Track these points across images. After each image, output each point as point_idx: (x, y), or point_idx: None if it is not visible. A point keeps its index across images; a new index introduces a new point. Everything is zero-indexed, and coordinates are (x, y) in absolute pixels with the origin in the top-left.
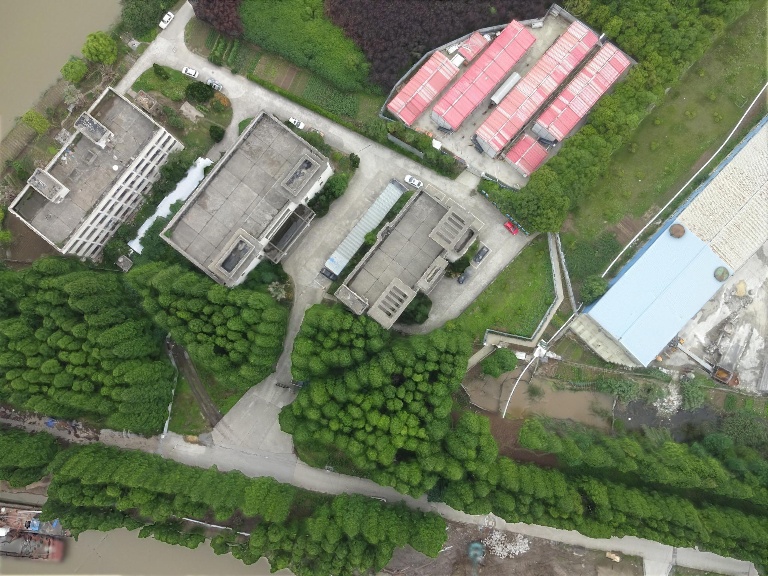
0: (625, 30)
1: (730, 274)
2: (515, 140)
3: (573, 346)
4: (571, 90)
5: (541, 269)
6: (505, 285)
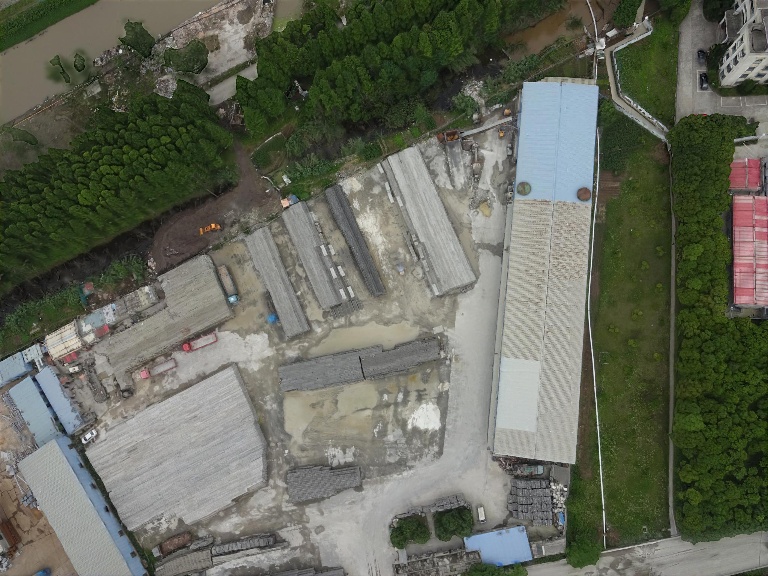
0: (762, 330)
1: (517, 194)
2: (763, 180)
3: (576, 73)
4: (763, 242)
5: (649, 106)
6: (667, 72)
